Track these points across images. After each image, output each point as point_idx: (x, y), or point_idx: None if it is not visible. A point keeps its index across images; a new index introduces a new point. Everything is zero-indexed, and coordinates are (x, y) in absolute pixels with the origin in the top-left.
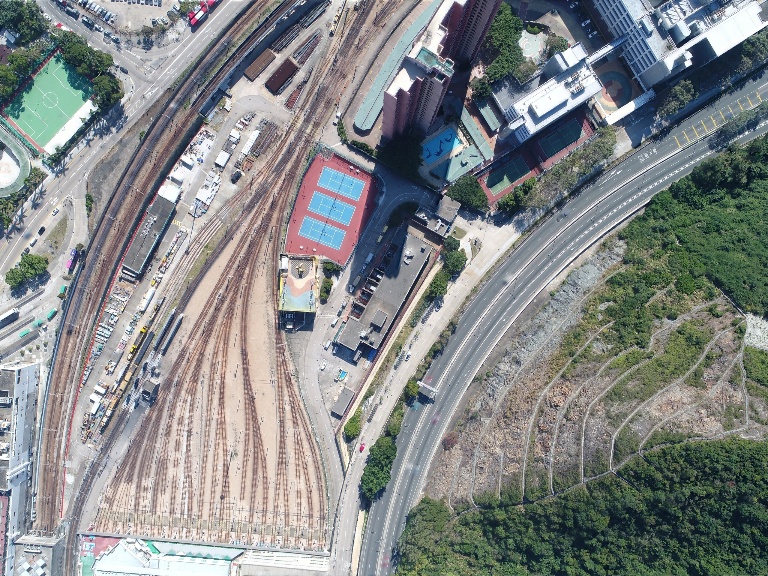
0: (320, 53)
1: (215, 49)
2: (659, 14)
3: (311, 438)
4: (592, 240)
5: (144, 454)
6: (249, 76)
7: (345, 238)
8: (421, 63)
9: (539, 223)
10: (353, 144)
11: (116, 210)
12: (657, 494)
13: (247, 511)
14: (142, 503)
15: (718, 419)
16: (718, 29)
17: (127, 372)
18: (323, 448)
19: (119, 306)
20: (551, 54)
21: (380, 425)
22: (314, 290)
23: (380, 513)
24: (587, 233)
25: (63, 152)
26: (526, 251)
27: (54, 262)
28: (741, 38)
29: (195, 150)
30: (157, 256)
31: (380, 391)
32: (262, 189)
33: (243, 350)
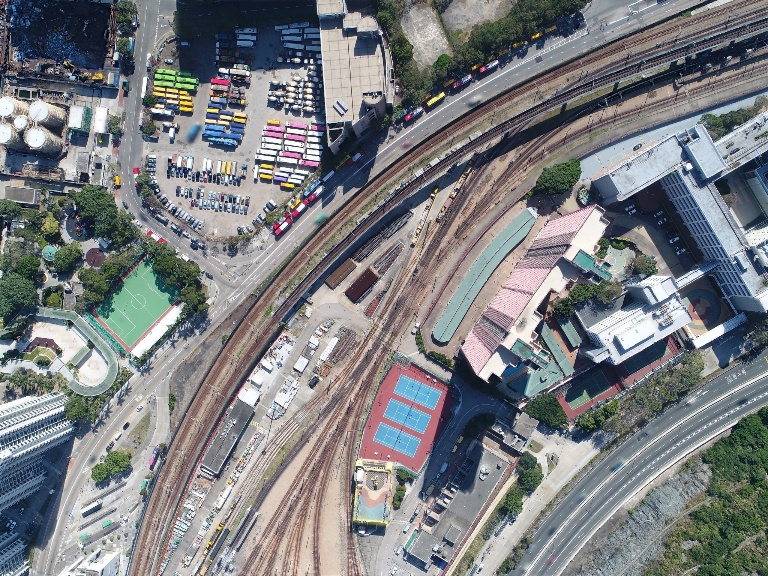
0: (401, 263)
1: (297, 257)
2: (756, 251)
3: None
4: (674, 460)
5: None
6: (330, 285)
7: (420, 446)
8: (516, 354)
9: (619, 442)
10: (431, 355)
11: (197, 409)
12: None
13: None
14: None
15: None
16: None
17: (202, 566)
18: None
19: (197, 502)
20: (637, 271)
21: None
22: (388, 502)
23: None
24: (669, 452)
25: (149, 353)
26: (605, 469)
27: (137, 456)
28: None
29: (275, 354)
30: (235, 455)
31: None
32: (339, 394)
33: (315, 550)
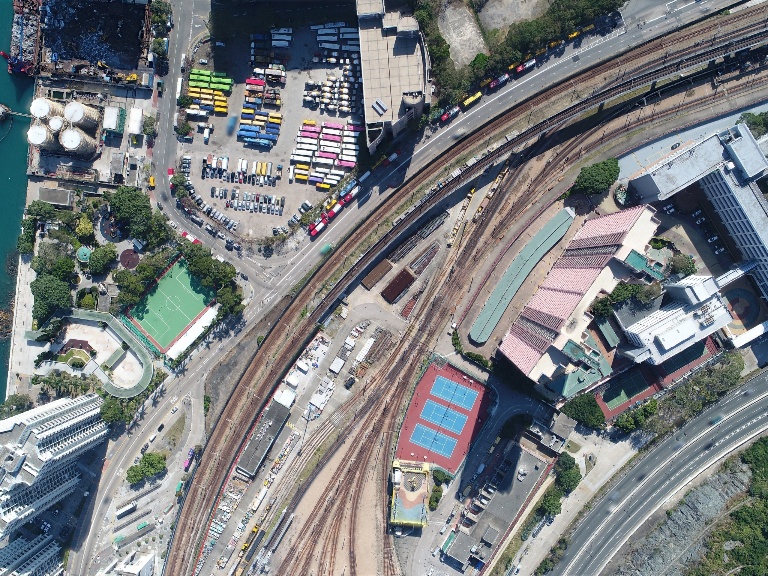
0: (437, 264)
1: (333, 258)
2: None
3: None
4: (713, 460)
5: None
6: (366, 285)
7: (456, 447)
8: (567, 355)
9: (657, 442)
10: (468, 356)
11: (232, 411)
12: None
13: None
14: None
15: None
16: None
17: (238, 567)
18: None
19: (232, 504)
20: (675, 271)
21: None
22: (426, 503)
23: None
24: (707, 452)
25: (184, 355)
26: (643, 469)
27: (171, 458)
28: None
29: (310, 355)
30: (270, 456)
31: None
32: (375, 395)
33: (351, 552)
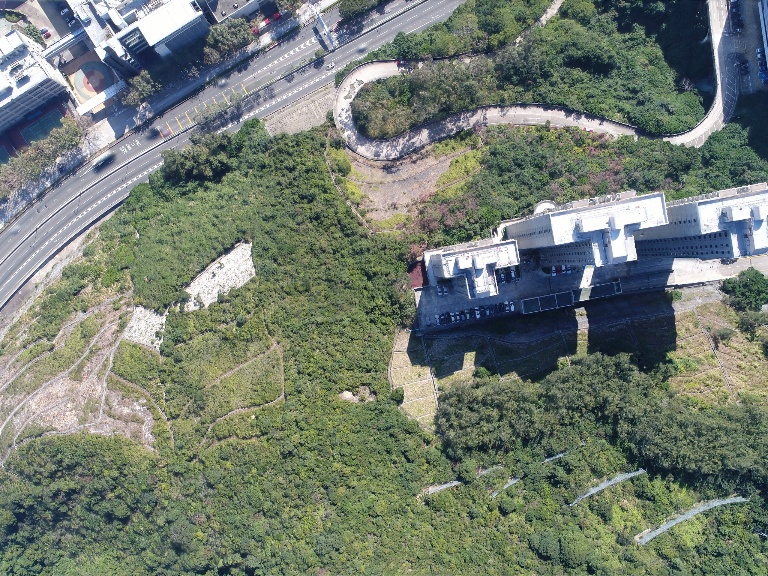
0: None
1: None
2: None
3: None
4: (76, 232)
5: None
6: None
7: None
8: None
9: (18, 214)
10: None
11: None
12: (35, 489)
13: None
14: None
15: (77, 413)
16: (150, 18)
17: None
18: None
19: None
20: None
21: None
22: None
23: None
24: (71, 225)
25: None
26: (6, 242)
27: None
28: (173, 28)
29: None
30: None
31: None
32: None
33: None
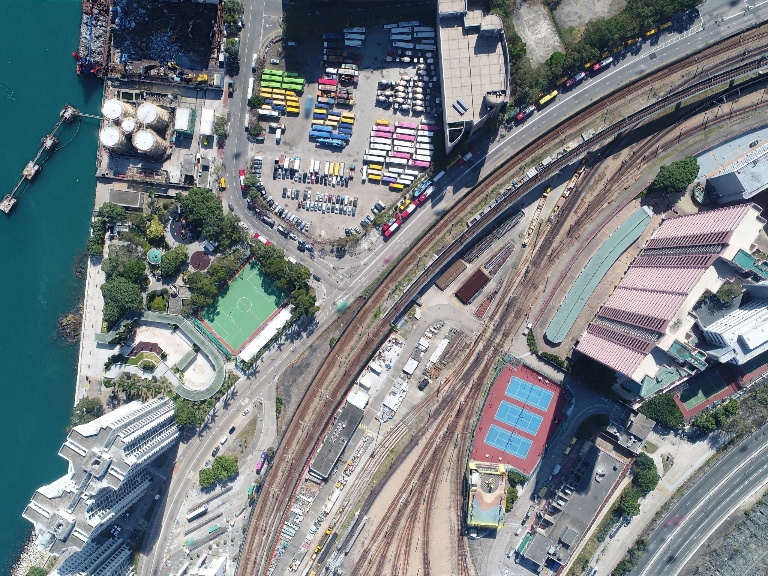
0: (512, 264)
1: (407, 258)
2: None
3: None
4: None
5: None
6: (440, 286)
7: (531, 448)
8: (673, 356)
9: (736, 442)
10: (544, 356)
11: (304, 413)
12: None
13: None
14: None
15: None
16: None
17: (310, 570)
18: None
19: (304, 506)
20: None
21: None
22: (503, 505)
23: None
24: None
25: (256, 357)
26: (721, 469)
27: (243, 461)
28: None
29: (384, 357)
30: (343, 459)
31: None
32: (449, 396)
33: (425, 554)
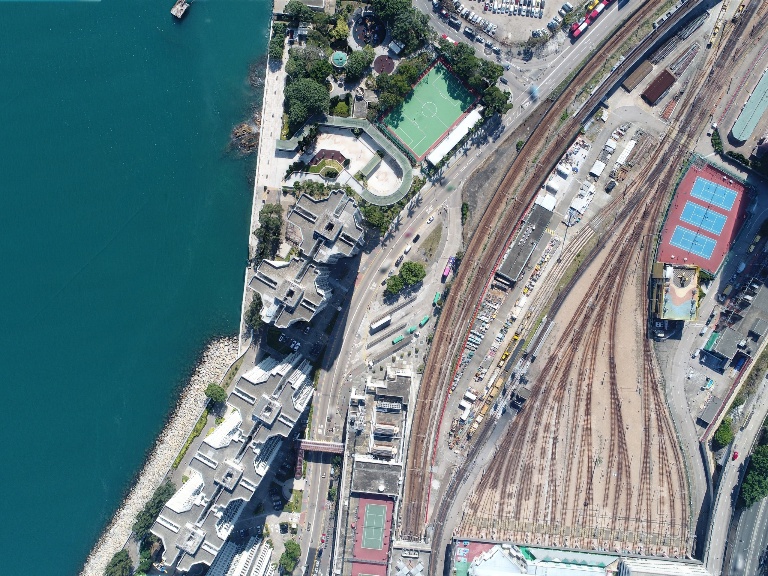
0: (697, 65)
1: (593, 60)
2: None
3: (676, 446)
4: None
5: (510, 460)
6: (627, 87)
7: (716, 248)
8: None
9: None
10: (730, 155)
11: (490, 218)
12: None
13: (610, 518)
14: (506, 509)
15: None
16: None
17: (496, 379)
18: (687, 456)
19: (491, 313)
20: None
21: (752, 434)
22: (695, 299)
23: (749, 522)
24: None
25: (443, 161)
26: None
27: (427, 269)
28: None
29: (570, 160)
30: (529, 264)
31: (752, 400)
32: (635, 199)
33: (611, 358)
